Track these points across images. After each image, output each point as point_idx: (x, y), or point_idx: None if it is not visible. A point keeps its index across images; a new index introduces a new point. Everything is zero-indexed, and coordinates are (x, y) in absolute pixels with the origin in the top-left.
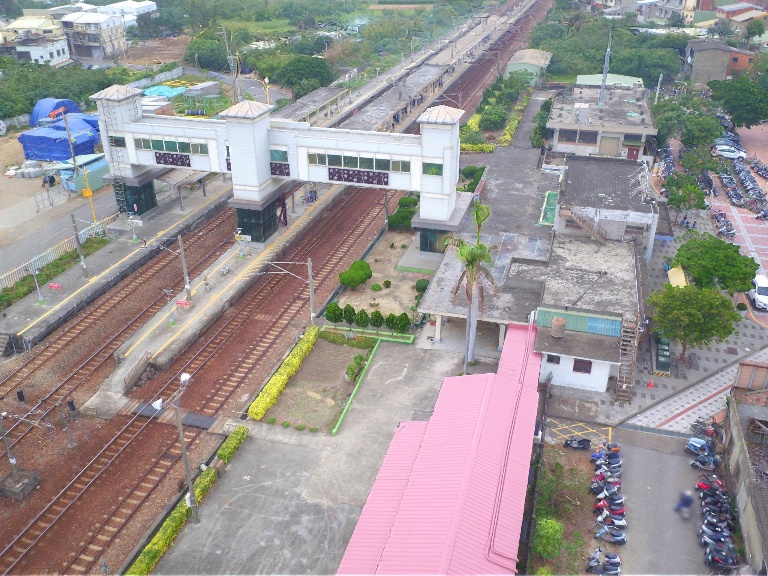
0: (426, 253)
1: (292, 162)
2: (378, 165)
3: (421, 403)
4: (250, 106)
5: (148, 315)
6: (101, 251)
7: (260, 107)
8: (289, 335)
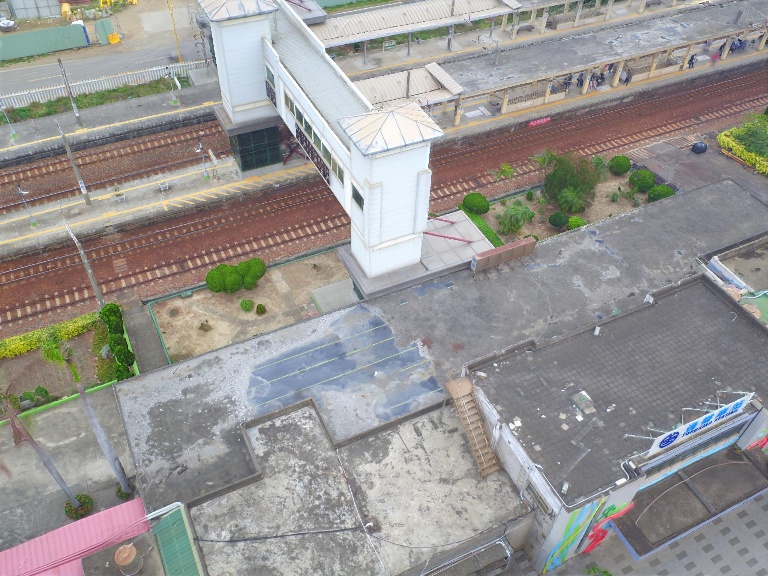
0: (356, 297)
1: (277, 92)
2: (326, 152)
3: (7, 495)
4: (227, 1)
5: (66, 197)
6: (137, 100)
7: (245, 6)
8: (98, 304)
